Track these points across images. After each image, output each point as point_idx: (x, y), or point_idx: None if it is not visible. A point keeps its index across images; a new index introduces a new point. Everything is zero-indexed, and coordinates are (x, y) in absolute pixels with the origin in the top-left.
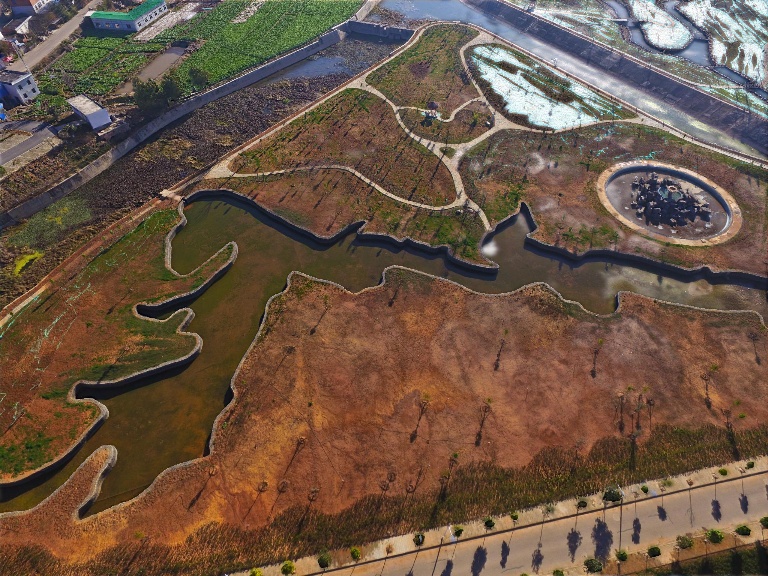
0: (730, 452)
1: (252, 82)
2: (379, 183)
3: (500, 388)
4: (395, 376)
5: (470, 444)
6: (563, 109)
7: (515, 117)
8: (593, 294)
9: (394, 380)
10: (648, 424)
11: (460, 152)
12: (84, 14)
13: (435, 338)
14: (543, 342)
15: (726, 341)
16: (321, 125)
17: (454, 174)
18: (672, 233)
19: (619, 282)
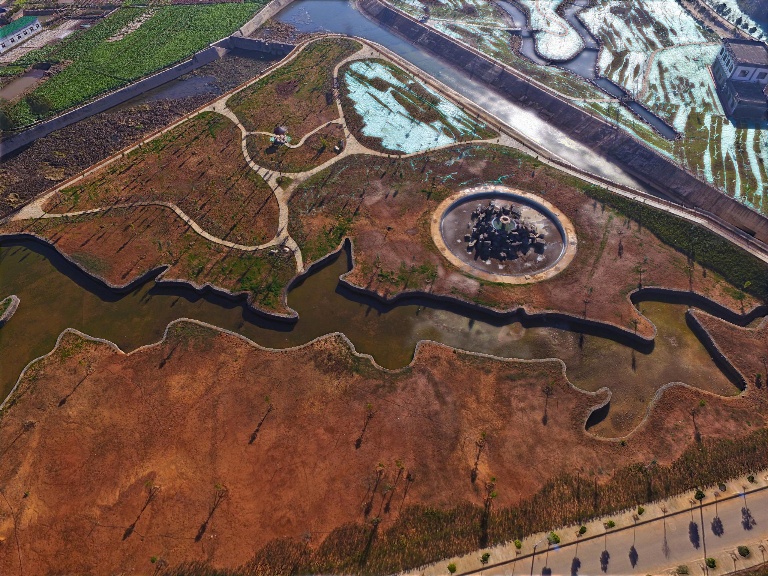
0: (478, 537)
1: (109, 106)
2: (198, 221)
3: (247, 466)
4: (134, 455)
5: (189, 539)
6: (423, 130)
7: (368, 140)
8: (394, 344)
9: (131, 461)
10: (399, 505)
11: (297, 182)
12: None
13: (196, 406)
14: (315, 406)
15: (517, 397)
16: None
17: (282, 208)
18: (499, 269)
19: (426, 328)
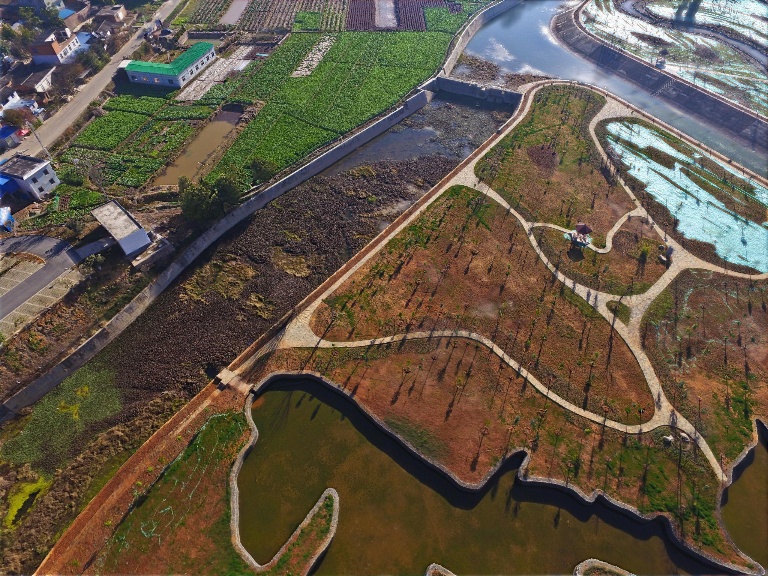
0: None
1: (325, 166)
2: (532, 371)
3: None
4: None
5: None
6: (759, 234)
7: (697, 247)
8: None
9: None
10: None
11: (637, 312)
12: (118, 62)
13: None
14: None
15: None
16: (429, 251)
17: (640, 357)
18: None
19: None
